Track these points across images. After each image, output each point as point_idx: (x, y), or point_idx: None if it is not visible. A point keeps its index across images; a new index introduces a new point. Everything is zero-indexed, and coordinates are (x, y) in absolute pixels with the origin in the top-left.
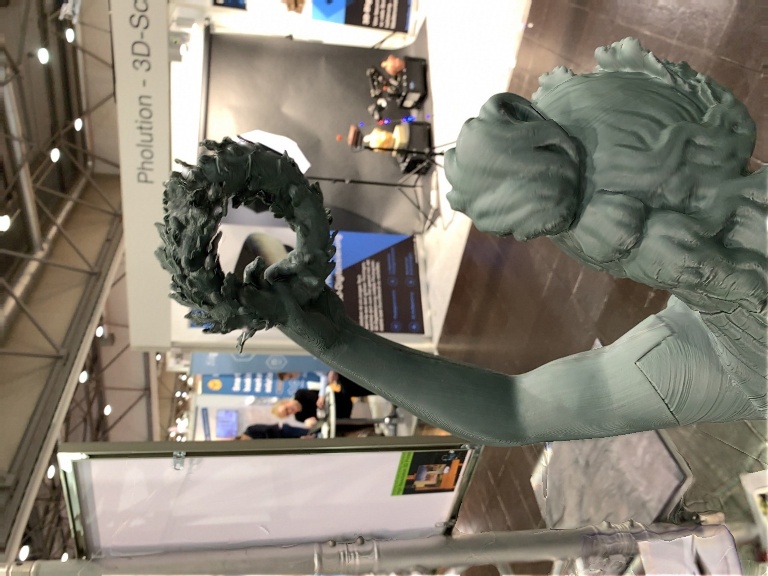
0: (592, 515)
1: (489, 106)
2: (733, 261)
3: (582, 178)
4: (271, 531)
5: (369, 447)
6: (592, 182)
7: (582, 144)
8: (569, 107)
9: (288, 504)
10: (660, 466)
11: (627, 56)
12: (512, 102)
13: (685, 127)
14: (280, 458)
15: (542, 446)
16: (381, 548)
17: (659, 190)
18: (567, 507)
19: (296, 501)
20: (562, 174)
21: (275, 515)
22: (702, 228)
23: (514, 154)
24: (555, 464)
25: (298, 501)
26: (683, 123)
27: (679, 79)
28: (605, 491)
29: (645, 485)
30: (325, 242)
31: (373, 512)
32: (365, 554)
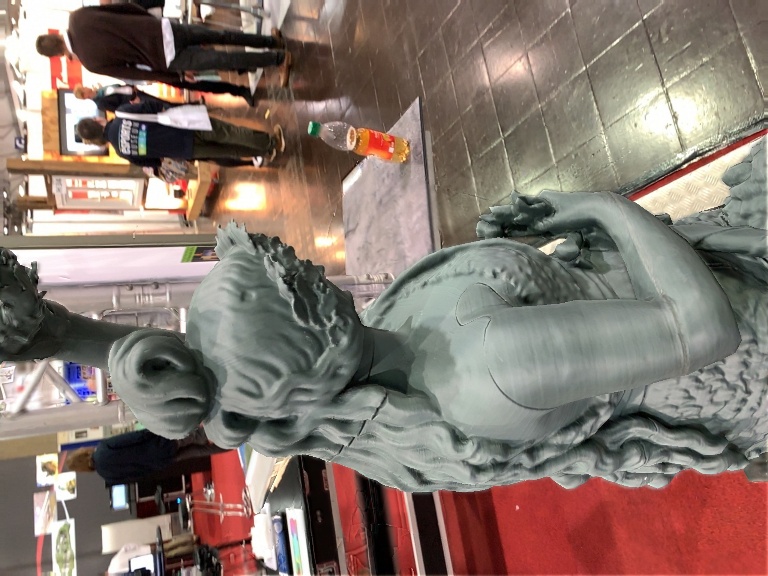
0: (373, 242)
1: (132, 364)
2: (310, 448)
3: (212, 399)
4: (72, 278)
5: (154, 245)
6: (219, 403)
7: (216, 377)
8: (215, 337)
9: (84, 267)
10: (422, 238)
11: (279, 288)
12: (155, 356)
13: (293, 382)
14: (67, 250)
15: (338, 197)
16: (173, 293)
17: (265, 416)
18: (359, 225)
19: (91, 266)
20: (188, 414)
21: (73, 272)
22: (288, 442)
23: (148, 407)
24: (360, 185)
25: (93, 265)
26: (293, 377)
27: (311, 323)
28: (385, 231)
29: (409, 245)
30: (32, 309)
31: (166, 269)
32: (159, 295)
